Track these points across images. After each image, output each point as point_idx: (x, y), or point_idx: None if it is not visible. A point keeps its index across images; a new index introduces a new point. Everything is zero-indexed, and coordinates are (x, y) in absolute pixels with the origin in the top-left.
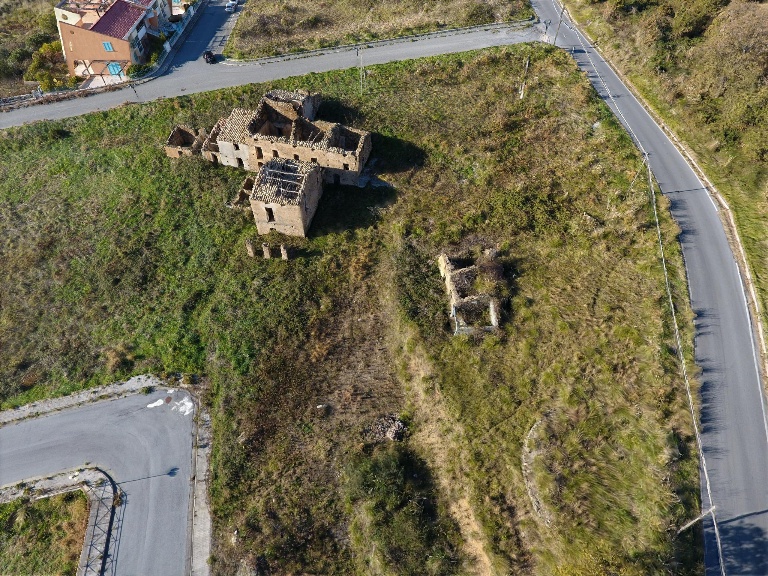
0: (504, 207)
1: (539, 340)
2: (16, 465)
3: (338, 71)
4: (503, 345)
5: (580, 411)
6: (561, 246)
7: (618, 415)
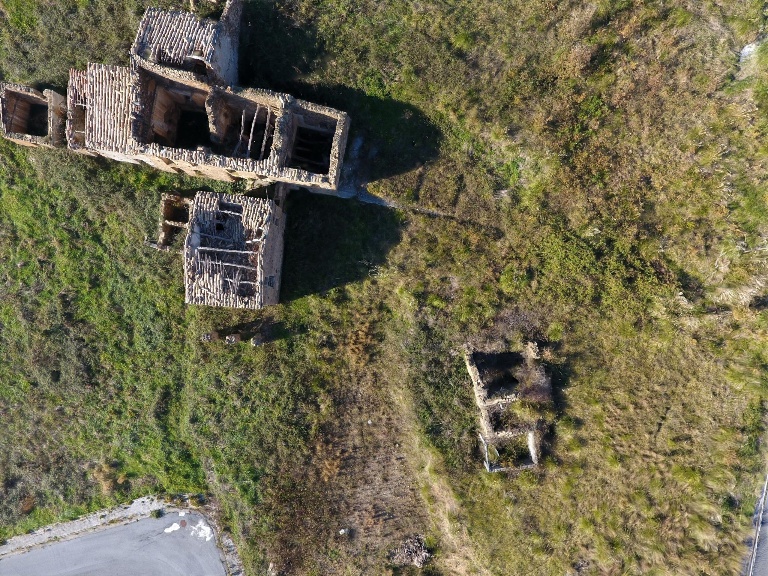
0: (562, 267)
1: (583, 479)
2: None
3: None
4: (540, 483)
5: (614, 571)
6: (633, 336)
7: (653, 574)
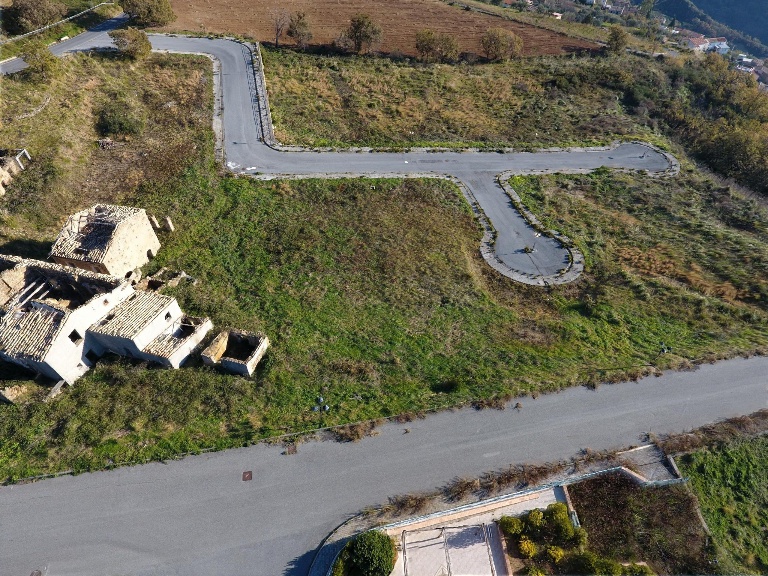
0: None
1: None
2: (326, 158)
3: None
4: None
5: None
6: None
7: None
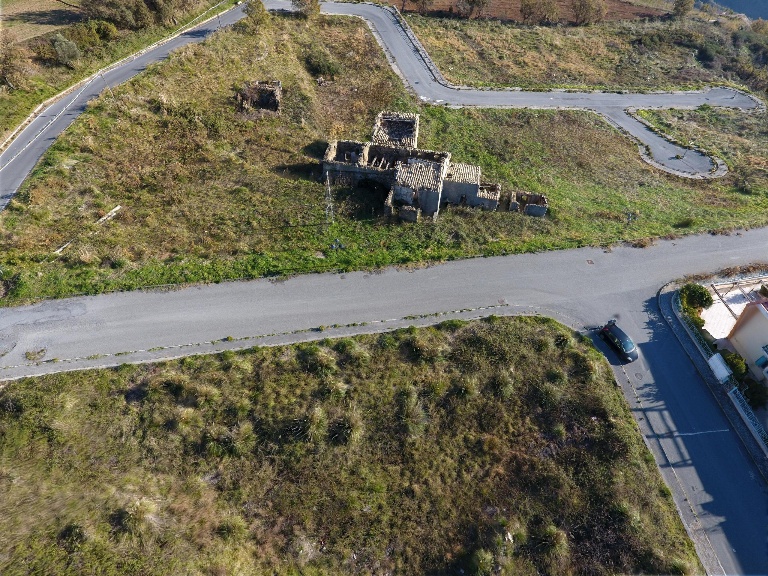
0: None
1: None
2: (490, 94)
3: (370, 260)
4: None
5: None
6: None
7: None
